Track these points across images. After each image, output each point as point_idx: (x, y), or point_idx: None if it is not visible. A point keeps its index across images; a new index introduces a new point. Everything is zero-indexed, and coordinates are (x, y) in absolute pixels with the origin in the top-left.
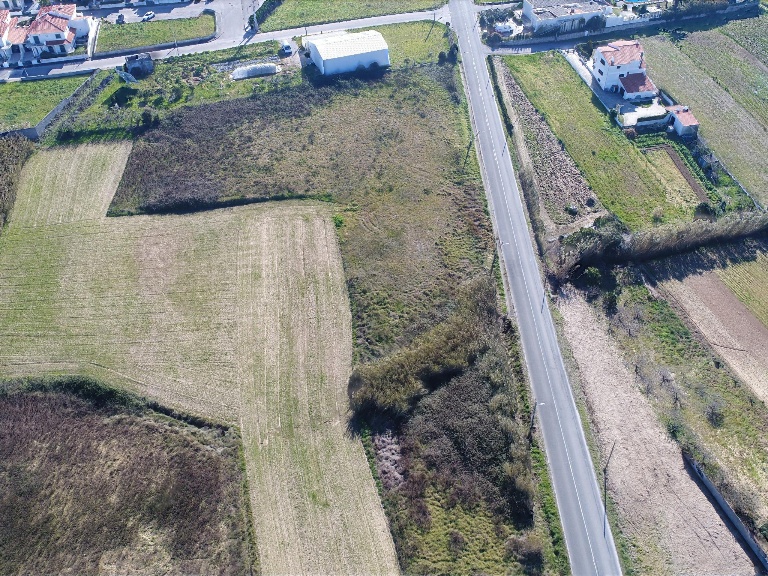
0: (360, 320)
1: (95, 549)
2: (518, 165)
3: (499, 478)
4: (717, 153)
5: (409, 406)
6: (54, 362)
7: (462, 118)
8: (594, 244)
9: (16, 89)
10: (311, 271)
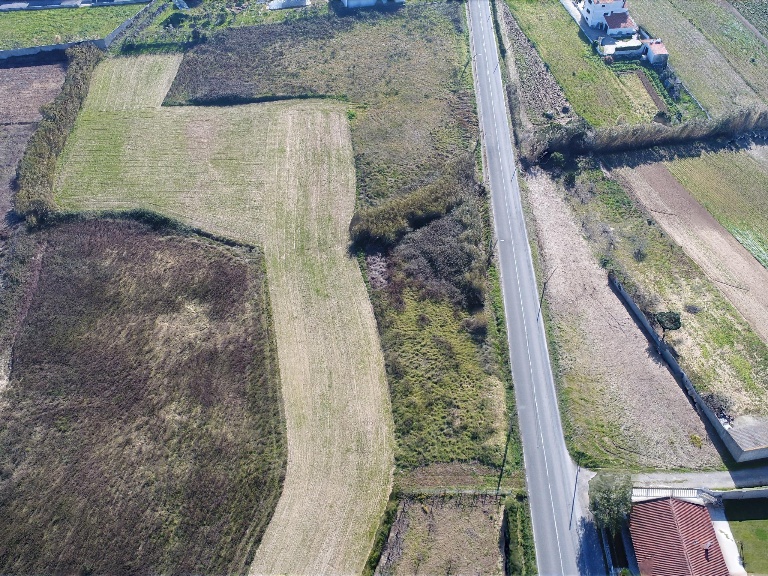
0: (363, 182)
1: (153, 313)
2: (507, 80)
3: (461, 283)
4: (683, 78)
5: (396, 237)
6: (121, 201)
7: (463, 44)
8: (561, 135)
9: (87, 12)
10: (326, 148)
